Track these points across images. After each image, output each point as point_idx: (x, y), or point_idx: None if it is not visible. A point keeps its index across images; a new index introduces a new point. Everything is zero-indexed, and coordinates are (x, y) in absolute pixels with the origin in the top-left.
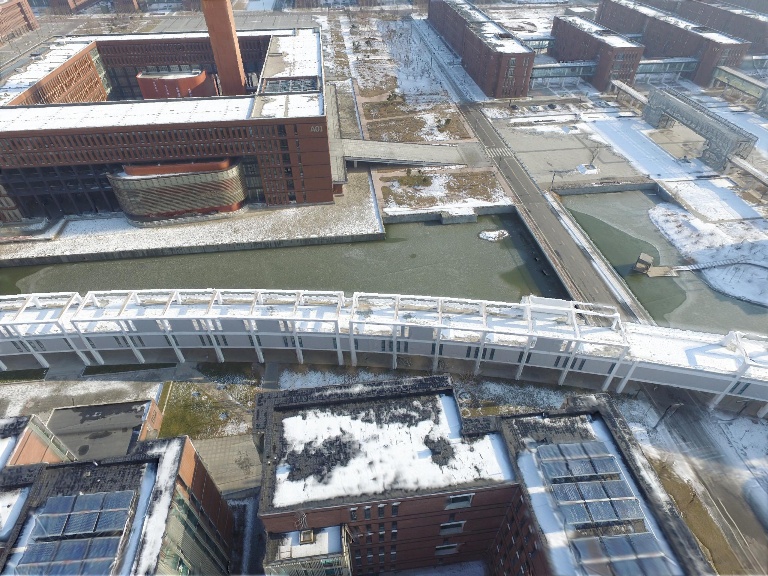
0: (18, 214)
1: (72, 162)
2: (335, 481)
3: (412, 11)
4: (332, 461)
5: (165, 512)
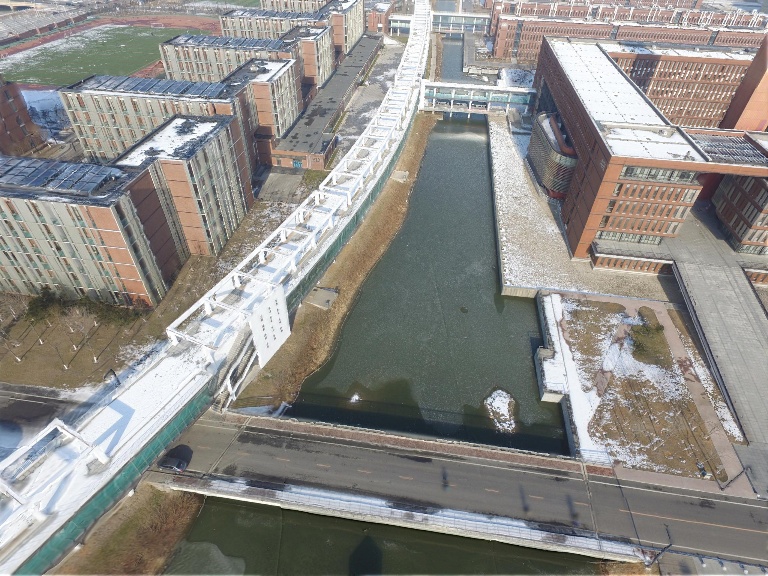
0: None
1: None
2: (172, 129)
3: None
4: (182, 129)
5: (199, 101)
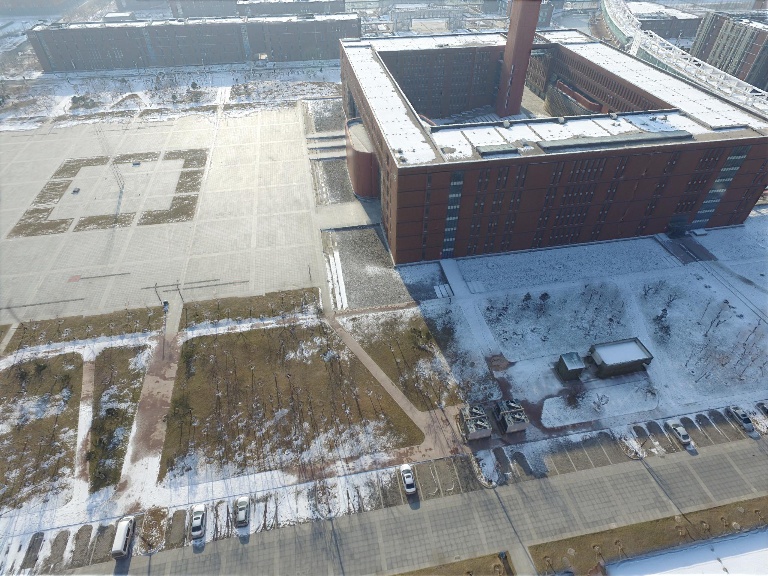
0: None
1: None
2: None
3: (2, 74)
4: None
5: None
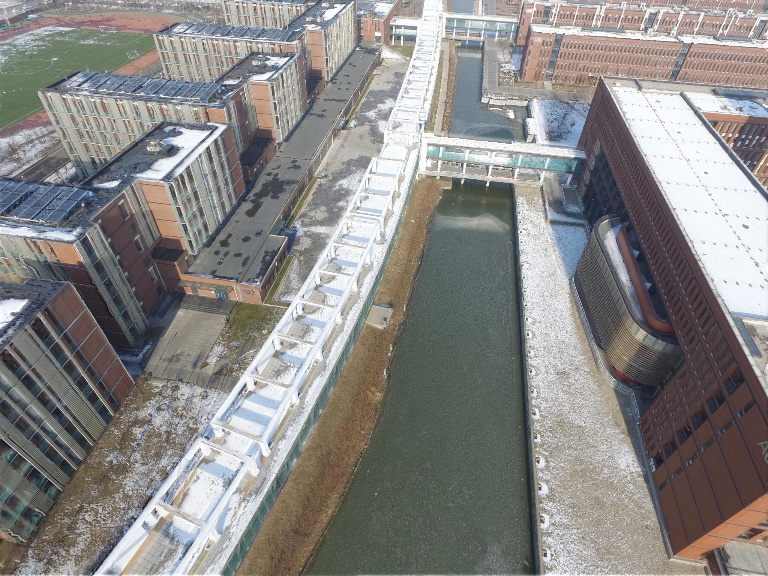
0: (583, 191)
1: (619, 183)
2: None
3: None
4: None
5: None
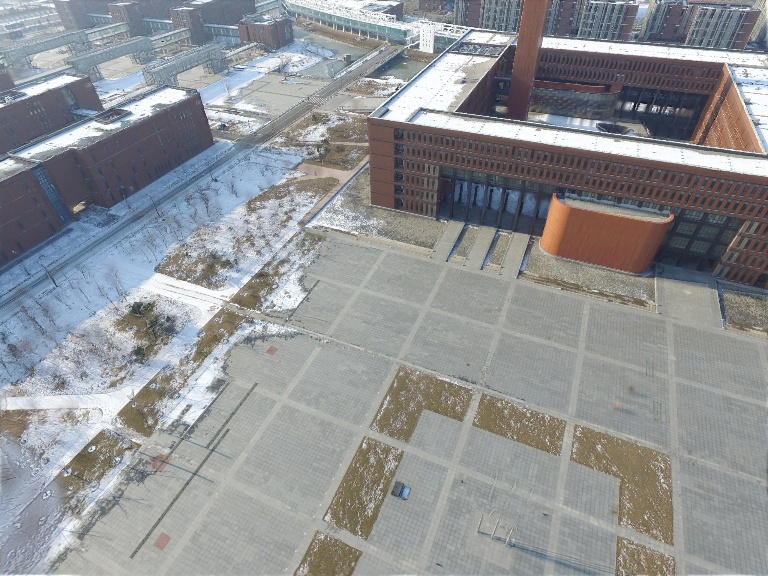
0: None
1: None
2: None
3: None
4: None
5: None
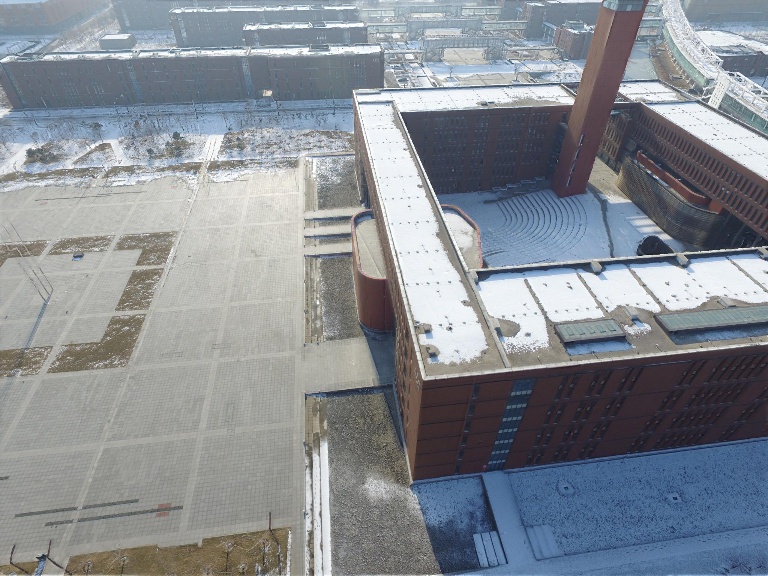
0: None
1: None
2: None
3: None
4: None
5: None
